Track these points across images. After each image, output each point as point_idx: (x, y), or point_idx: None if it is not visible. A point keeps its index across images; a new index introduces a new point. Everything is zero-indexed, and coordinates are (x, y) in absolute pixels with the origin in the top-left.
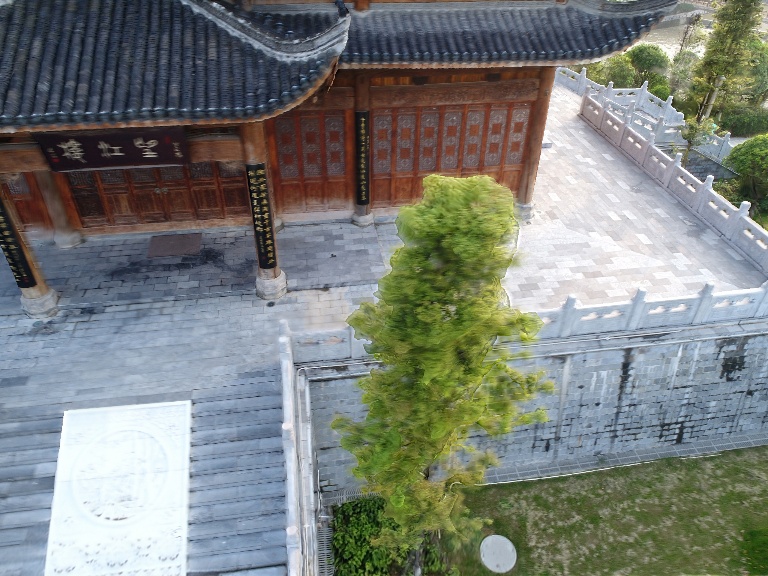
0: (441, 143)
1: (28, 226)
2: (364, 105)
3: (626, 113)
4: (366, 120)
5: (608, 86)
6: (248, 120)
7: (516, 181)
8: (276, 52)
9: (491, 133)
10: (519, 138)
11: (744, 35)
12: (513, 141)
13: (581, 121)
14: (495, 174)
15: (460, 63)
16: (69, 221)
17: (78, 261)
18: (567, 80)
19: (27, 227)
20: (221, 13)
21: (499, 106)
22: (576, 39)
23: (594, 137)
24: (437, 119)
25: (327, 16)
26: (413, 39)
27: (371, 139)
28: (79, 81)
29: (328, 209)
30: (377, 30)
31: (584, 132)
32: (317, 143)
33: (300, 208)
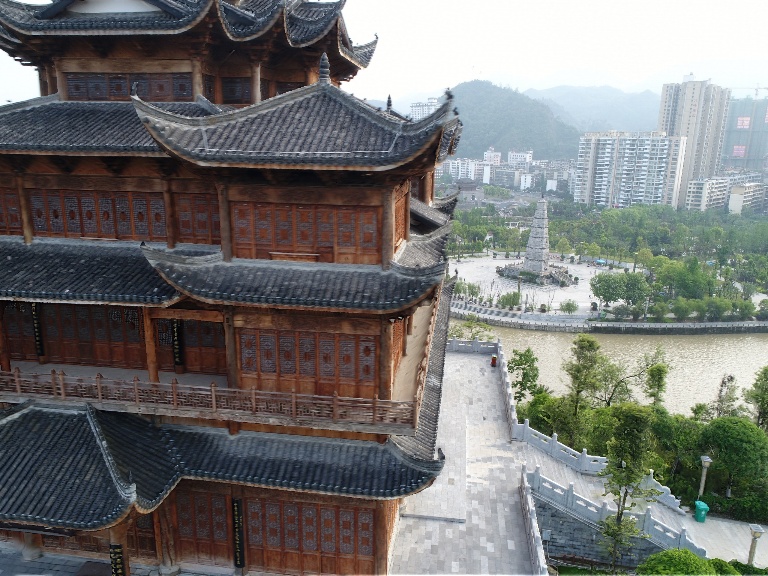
0: (301, 529)
1: (10, 538)
2: (237, 494)
3: (566, 493)
4: (239, 505)
5: (582, 452)
6: (84, 529)
7: (371, 569)
8: (118, 484)
9: (342, 528)
10: (367, 535)
11: (637, 454)
12: (362, 537)
13: (517, 495)
14: (351, 560)
15: (281, 487)
16: (34, 540)
17: (25, 575)
18: (539, 442)
19: (9, 539)
20: (104, 449)
21: (346, 508)
22: (379, 478)
23: (515, 517)
24: (296, 511)
25: (208, 436)
26: (256, 463)
27: (246, 518)
28: (5, 486)
29: (215, 564)
30: (235, 452)
31: (510, 509)
32: (206, 514)
33: (194, 560)
